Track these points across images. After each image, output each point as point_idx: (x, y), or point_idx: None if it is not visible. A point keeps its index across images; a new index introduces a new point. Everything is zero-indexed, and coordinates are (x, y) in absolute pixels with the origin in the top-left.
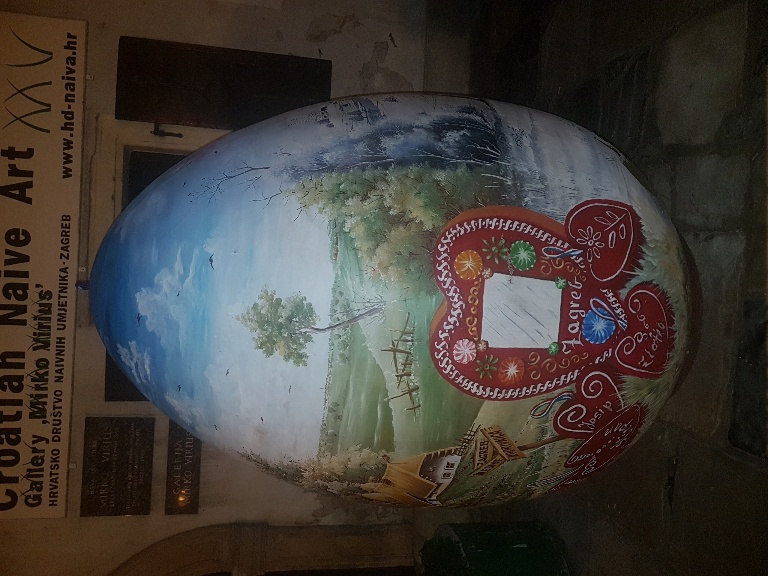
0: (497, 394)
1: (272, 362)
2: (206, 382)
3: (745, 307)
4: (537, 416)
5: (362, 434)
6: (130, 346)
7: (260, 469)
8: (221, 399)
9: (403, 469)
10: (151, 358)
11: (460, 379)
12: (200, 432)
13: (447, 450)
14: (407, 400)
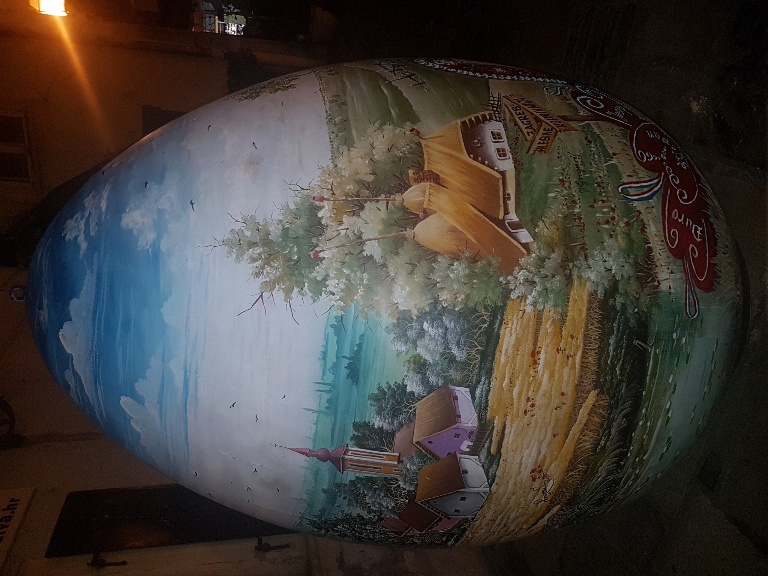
0: (497, 77)
1: (259, 100)
2: (182, 151)
3: (696, 143)
4: (553, 94)
5: (375, 112)
6: (85, 203)
7: (258, 284)
8: (201, 155)
9: (443, 147)
10: (112, 185)
11: (453, 70)
12: (167, 250)
13: (480, 116)
14: (409, 81)
